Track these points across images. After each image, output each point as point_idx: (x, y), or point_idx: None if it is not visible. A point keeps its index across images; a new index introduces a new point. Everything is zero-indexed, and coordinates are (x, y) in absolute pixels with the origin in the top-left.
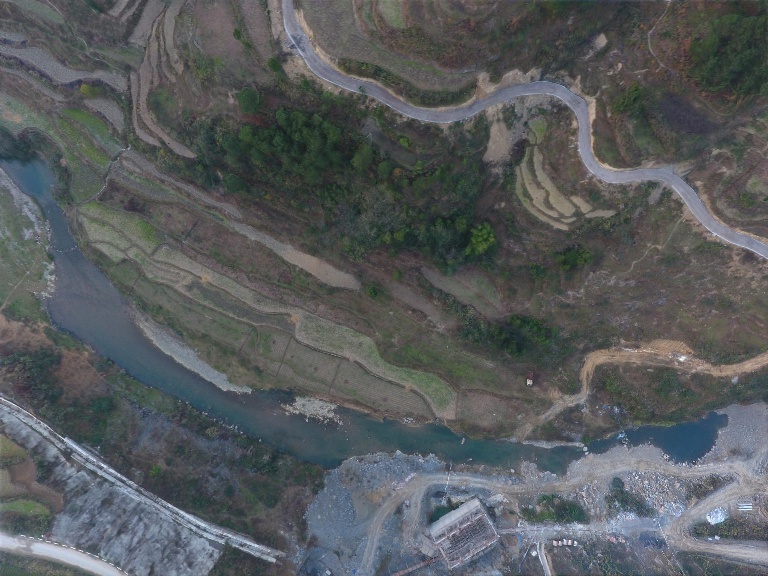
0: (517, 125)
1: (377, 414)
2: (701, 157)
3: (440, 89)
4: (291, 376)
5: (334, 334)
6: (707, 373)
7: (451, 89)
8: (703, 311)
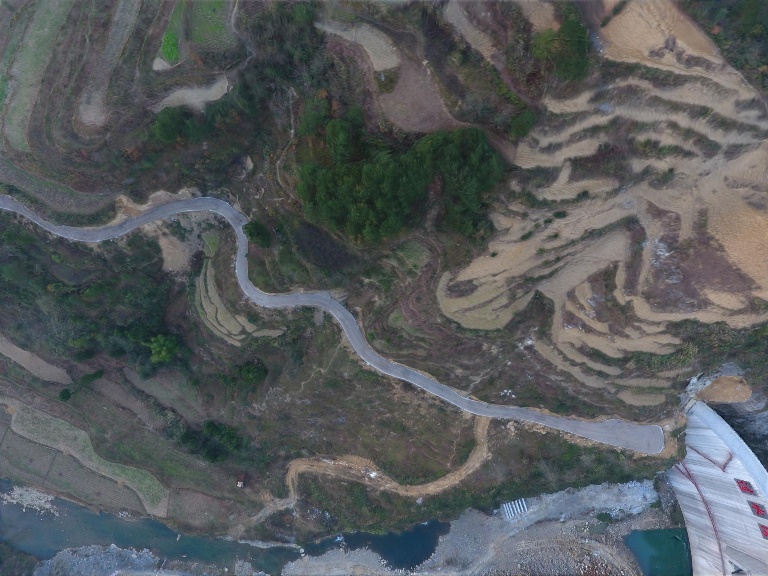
0: (190, 238)
1: (92, 507)
2: (351, 285)
3: (76, 211)
4: (6, 467)
5: (49, 427)
6: (394, 491)
7: (87, 212)
8: (382, 432)
